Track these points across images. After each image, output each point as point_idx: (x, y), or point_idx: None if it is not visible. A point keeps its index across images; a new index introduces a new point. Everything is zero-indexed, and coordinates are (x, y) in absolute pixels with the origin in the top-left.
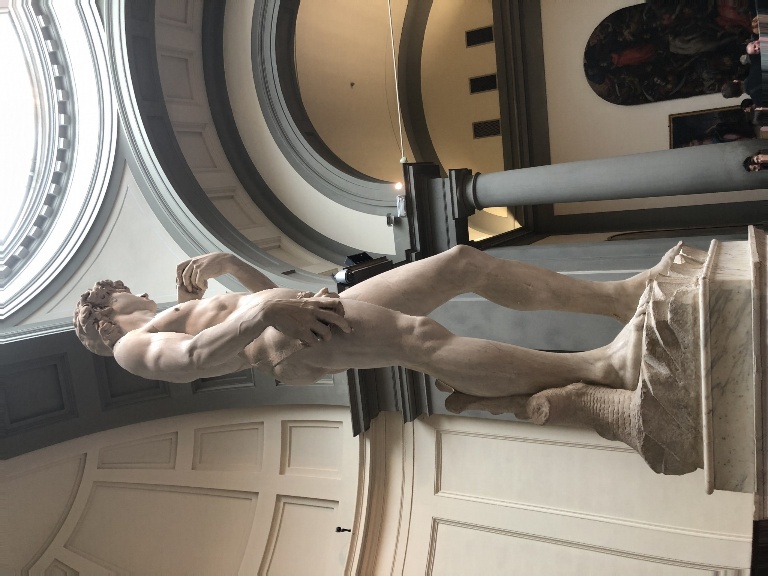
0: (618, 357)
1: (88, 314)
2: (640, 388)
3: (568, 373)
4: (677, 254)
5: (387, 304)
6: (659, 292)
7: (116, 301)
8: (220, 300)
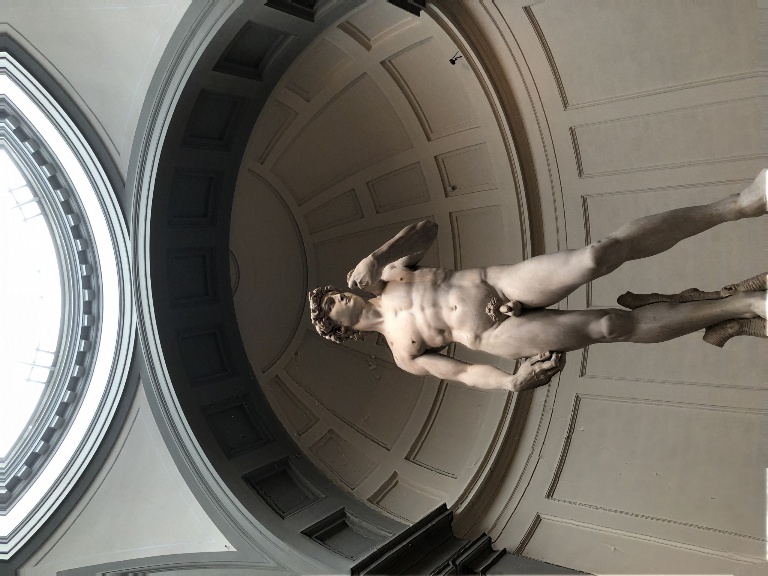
0: None
1: (339, 339)
2: None
3: None
4: None
5: None
6: None
7: (341, 322)
8: (434, 328)
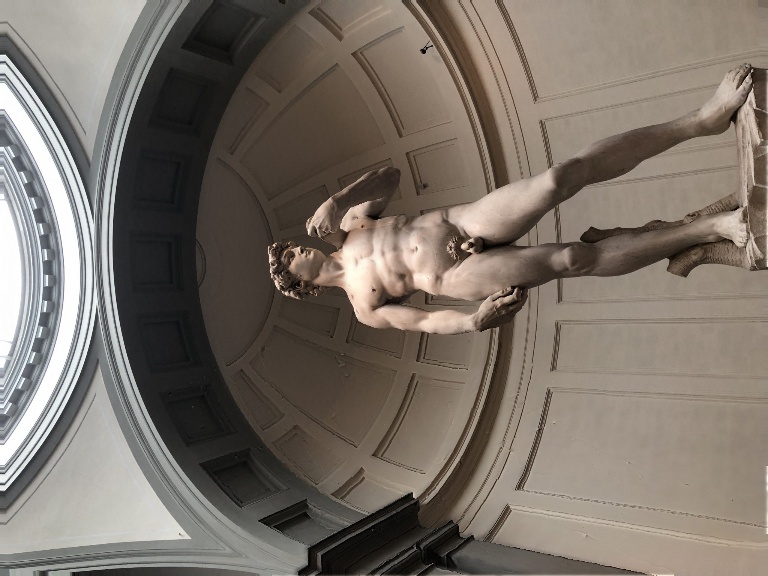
0: (725, 237)
1: (298, 295)
2: (749, 266)
3: (689, 245)
4: (749, 91)
5: (521, 231)
6: (757, 250)
7: (301, 276)
8: (395, 272)
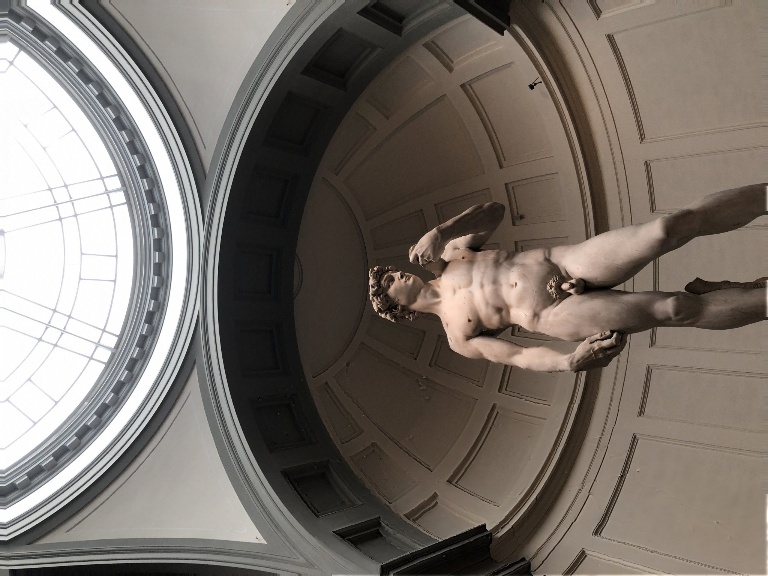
0: None
1: (394, 318)
2: None
3: None
4: None
5: (624, 276)
6: None
7: (399, 300)
8: (492, 305)
